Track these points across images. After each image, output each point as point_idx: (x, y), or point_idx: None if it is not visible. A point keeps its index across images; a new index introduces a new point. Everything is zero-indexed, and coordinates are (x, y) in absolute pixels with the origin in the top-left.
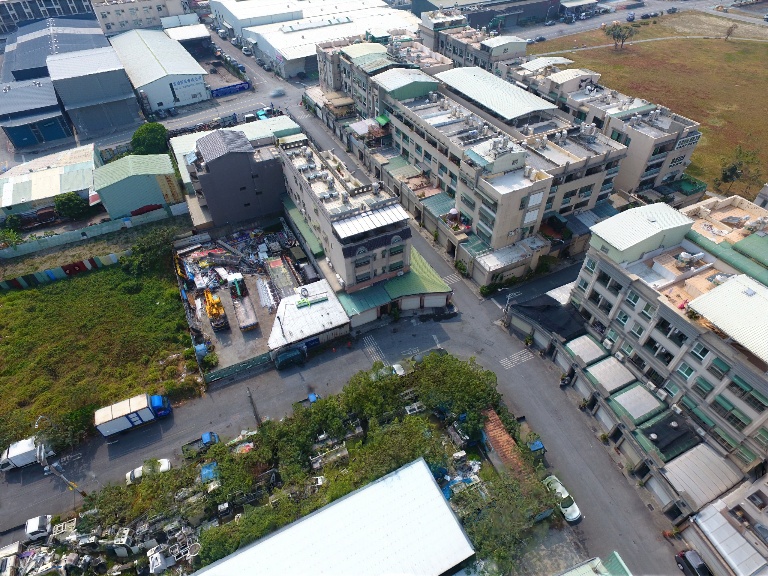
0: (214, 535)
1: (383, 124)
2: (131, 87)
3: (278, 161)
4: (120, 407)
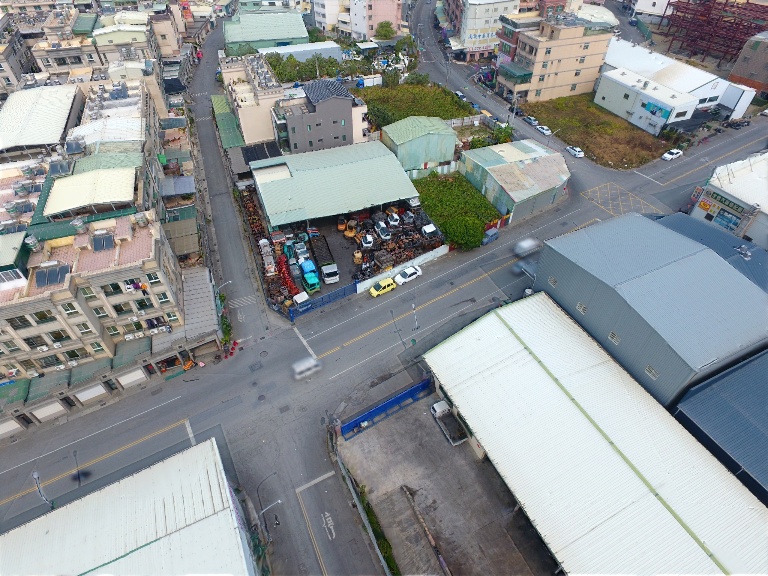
0: (330, 58)
1: (165, 155)
2: (541, 275)
3: (288, 107)
4: (373, 76)
